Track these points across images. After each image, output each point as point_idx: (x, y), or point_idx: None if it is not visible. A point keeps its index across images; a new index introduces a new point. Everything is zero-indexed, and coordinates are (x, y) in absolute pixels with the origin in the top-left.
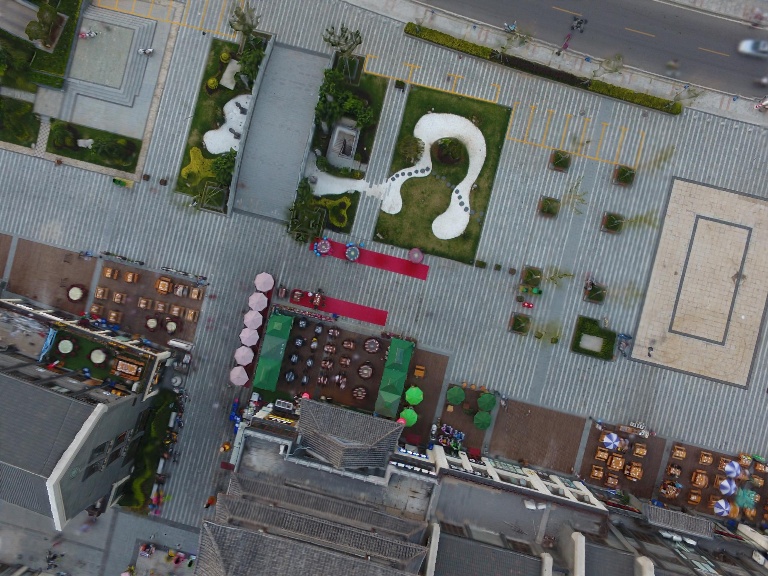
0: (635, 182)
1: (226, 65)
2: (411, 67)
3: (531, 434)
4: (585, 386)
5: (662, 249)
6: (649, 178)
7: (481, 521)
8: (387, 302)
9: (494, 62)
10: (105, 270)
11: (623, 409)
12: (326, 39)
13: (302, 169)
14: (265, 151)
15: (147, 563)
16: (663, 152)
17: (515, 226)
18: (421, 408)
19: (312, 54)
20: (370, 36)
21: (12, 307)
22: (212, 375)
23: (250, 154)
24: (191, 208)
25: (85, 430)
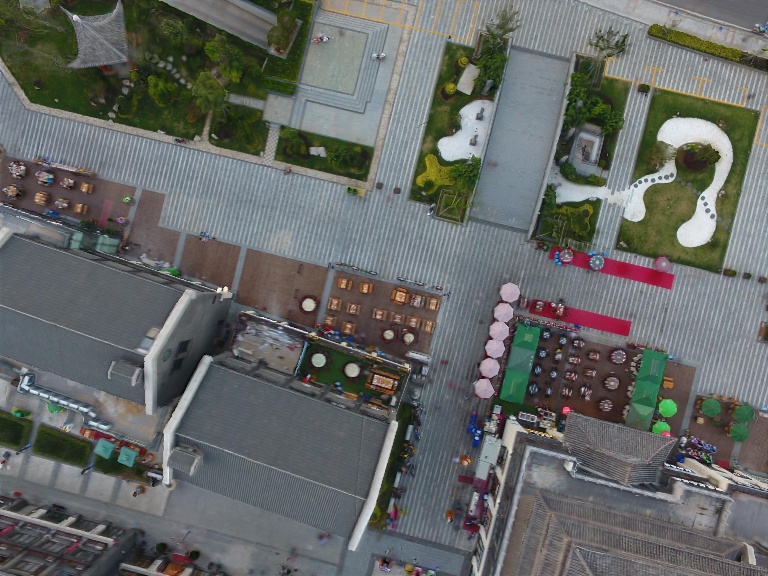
0: None
1: (463, 70)
2: (654, 70)
3: None
4: None
5: None
6: None
7: None
8: (631, 312)
9: (742, 64)
10: (339, 281)
11: None
12: (592, 43)
13: (548, 176)
14: (507, 158)
15: None
16: None
17: (764, 233)
18: (667, 420)
19: (550, 57)
20: None
21: (261, 320)
22: (448, 387)
23: (491, 161)
24: (426, 217)
25: (388, 449)
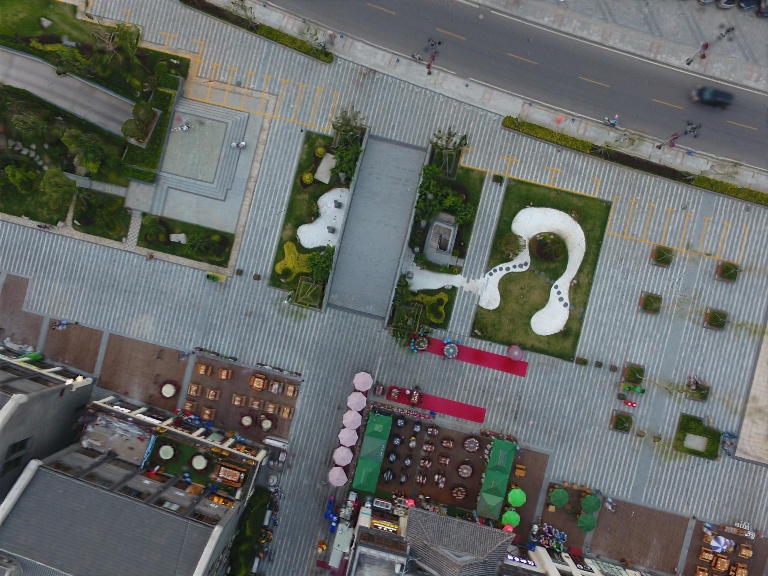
0: (738, 278)
1: (321, 159)
2: (508, 160)
3: (633, 534)
4: (688, 485)
5: (766, 346)
6: (752, 274)
7: None
8: (485, 399)
9: (593, 156)
10: (199, 367)
11: (727, 508)
12: (432, 142)
13: (401, 267)
14: (362, 247)
15: None
16: (766, 247)
17: (616, 322)
18: (521, 507)
19: (407, 147)
20: (466, 129)
21: (111, 411)
22: (307, 472)
23: (347, 250)
24: (285, 303)
25: (206, 557)
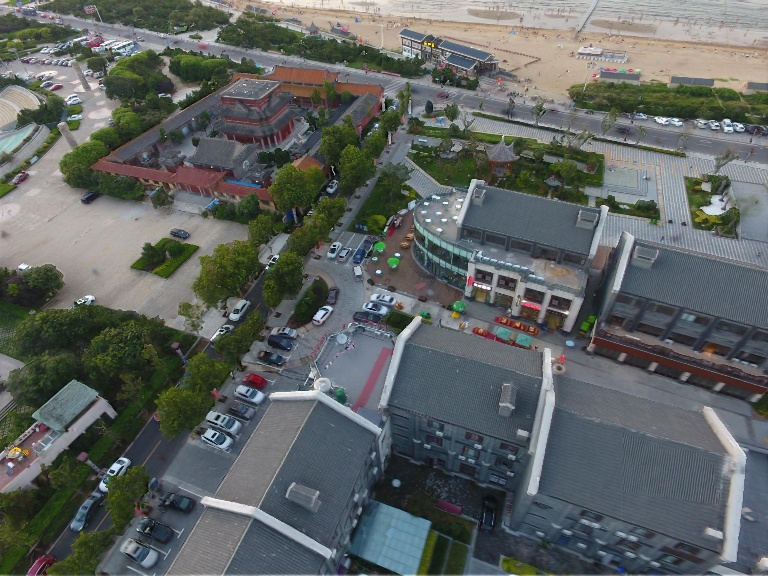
0: None
1: (701, 183)
2: None
3: None
4: None
5: None
6: None
7: None
8: None
9: None
10: None
11: None
12: None
13: None
14: (752, 212)
15: None
16: None
17: None
18: None
19: (751, 183)
20: None
21: None
22: None
23: (743, 213)
24: (710, 236)
25: None
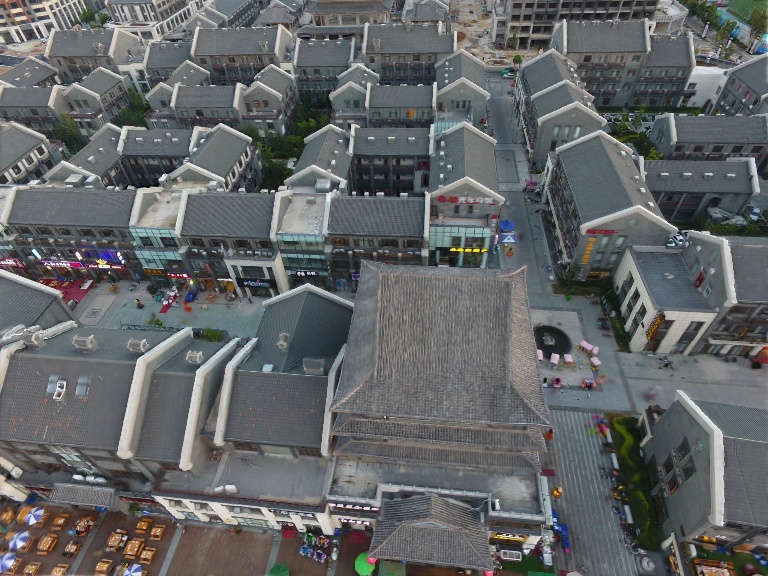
0: None
1: None
2: None
3: (224, 567)
4: None
5: None
6: None
7: (282, 464)
8: None
9: None
10: None
11: None
12: None
13: None
14: None
15: (583, 374)
16: None
17: None
18: None
19: None
20: None
21: None
22: None
23: None
24: None
25: (719, 492)
